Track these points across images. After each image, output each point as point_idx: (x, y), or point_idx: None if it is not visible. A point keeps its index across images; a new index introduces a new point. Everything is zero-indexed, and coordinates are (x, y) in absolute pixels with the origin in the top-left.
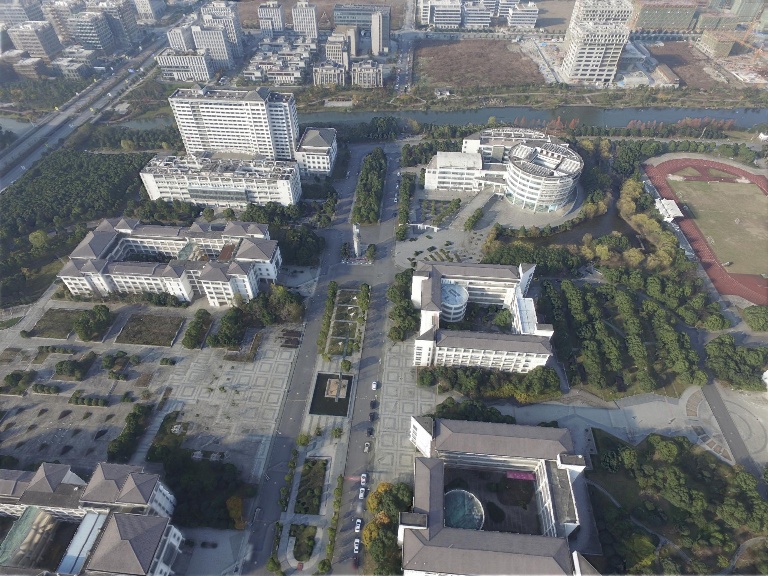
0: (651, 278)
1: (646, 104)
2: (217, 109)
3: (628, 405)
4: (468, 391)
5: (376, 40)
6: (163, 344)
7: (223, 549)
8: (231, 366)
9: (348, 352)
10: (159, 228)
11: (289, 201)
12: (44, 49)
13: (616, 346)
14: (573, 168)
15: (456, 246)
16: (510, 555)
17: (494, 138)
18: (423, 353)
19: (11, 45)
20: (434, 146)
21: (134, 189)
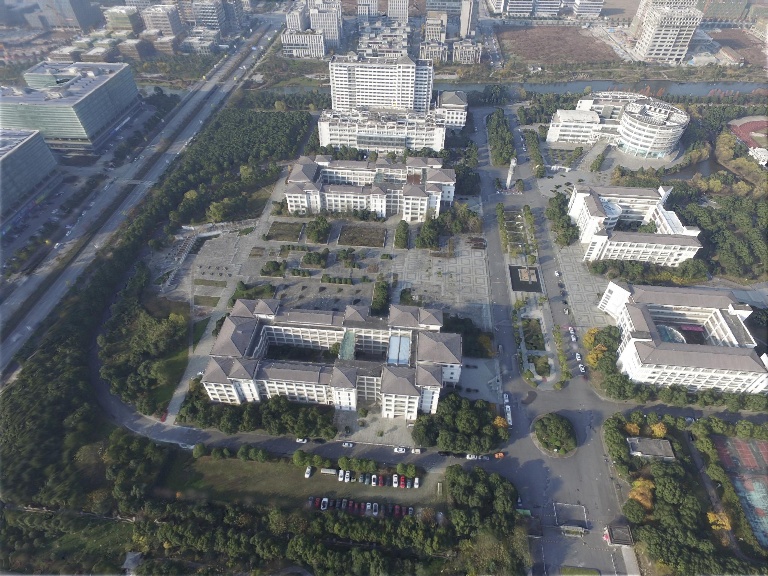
0: (760, 203)
1: (717, 79)
2: (370, 72)
3: (761, 288)
4: (635, 276)
5: (465, 24)
6: (377, 246)
7: (483, 369)
8: (438, 260)
9: (528, 252)
10: (351, 161)
11: (440, 147)
12: (172, 30)
13: (746, 247)
14: (682, 120)
15: (587, 182)
16: (718, 355)
17: (603, 100)
18: (595, 249)
19: (139, 26)
20: (545, 108)
21: (302, 138)
